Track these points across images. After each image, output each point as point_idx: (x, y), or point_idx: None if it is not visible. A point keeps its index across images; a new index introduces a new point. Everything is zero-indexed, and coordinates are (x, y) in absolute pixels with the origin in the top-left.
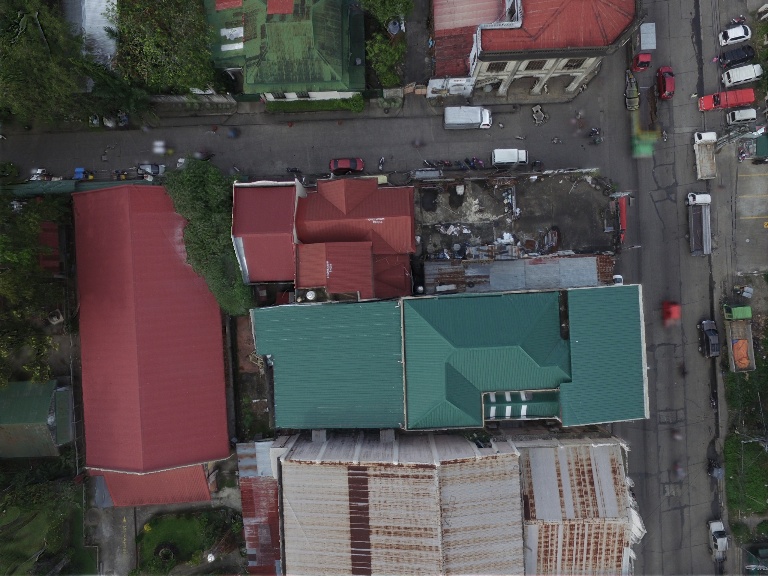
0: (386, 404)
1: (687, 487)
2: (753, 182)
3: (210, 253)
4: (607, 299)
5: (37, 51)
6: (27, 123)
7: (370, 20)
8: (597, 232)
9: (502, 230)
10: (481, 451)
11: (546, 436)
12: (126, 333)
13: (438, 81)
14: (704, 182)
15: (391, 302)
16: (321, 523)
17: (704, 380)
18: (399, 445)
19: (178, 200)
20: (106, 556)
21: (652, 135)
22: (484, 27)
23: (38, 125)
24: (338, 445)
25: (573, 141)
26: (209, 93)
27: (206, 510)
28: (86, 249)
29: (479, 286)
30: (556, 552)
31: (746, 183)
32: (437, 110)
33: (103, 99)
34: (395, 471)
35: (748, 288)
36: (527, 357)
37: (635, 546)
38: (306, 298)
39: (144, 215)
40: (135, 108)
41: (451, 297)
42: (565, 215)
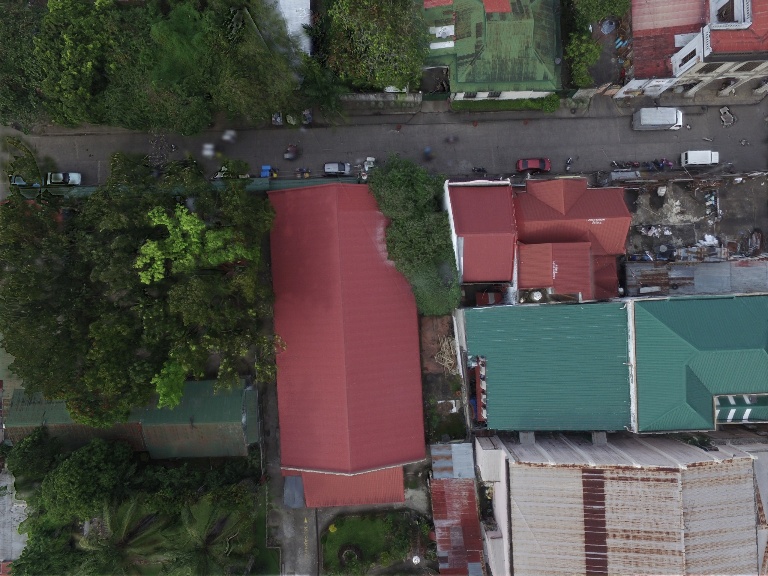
0: (609, 406)
1: None
2: None
3: (421, 253)
4: None
5: (259, 47)
6: None
7: (565, 20)
8: None
9: (703, 232)
10: None
11: (765, 440)
12: (331, 332)
13: (643, 82)
14: None
15: (616, 303)
16: (552, 526)
17: None
18: (617, 448)
19: (391, 199)
20: (287, 557)
21: None
22: (712, 28)
23: (221, 122)
24: (552, 447)
25: (761, 143)
26: (403, 92)
27: (390, 512)
28: (283, 247)
29: (683, 288)
30: None
31: None
32: (624, 111)
33: (309, 97)
34: (634, 474)
35: None
36: (767, 360)
37: None
38: (527, 299)
39: (350, 214)
40: (335, 106)
41: (683, 299)
42: (767, 217)
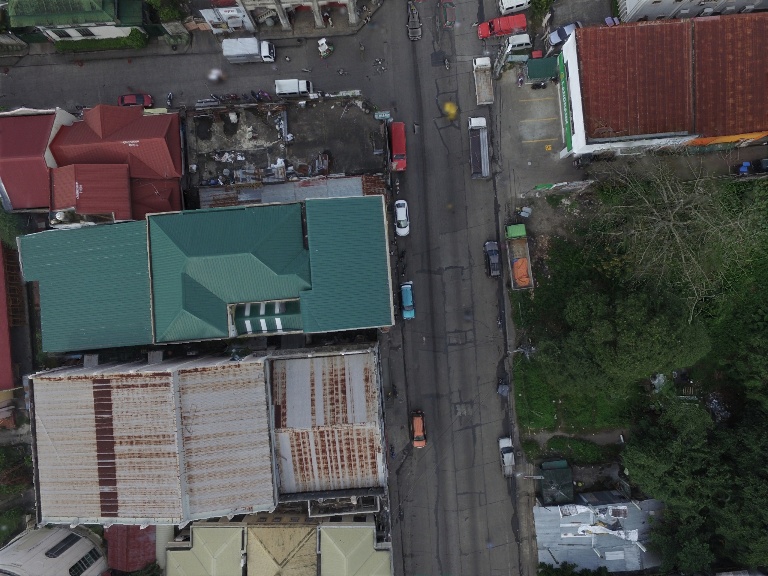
0: (141, 322)
1: (478, 406)
2: (534, 107)
3: None
4: (348, 209)
5: None
6: None
7: None
8: (369, 155)
9: (276, 156)
10: None
11: (306, 350)
12: None
13: (206, 11)
14: (487, 108)
15: (143, 221)
16: (70, 438)
17: (492, 301)
18: (161, 363)
19: None
20: None
21: (434, 64)
22: None
23: None
24: (104, 367)
25: (358, 72)
26: None
27: (4, 447)
28: None
29: None
30: (311, 460)
31: (527, 108)
32: None
33: None
34: (135, 381)
35: (526, 208)
36: (262, 265)
37: (429, 466)
38: None
39: None
40: None
41: (195, 212)
42: (337, 139)
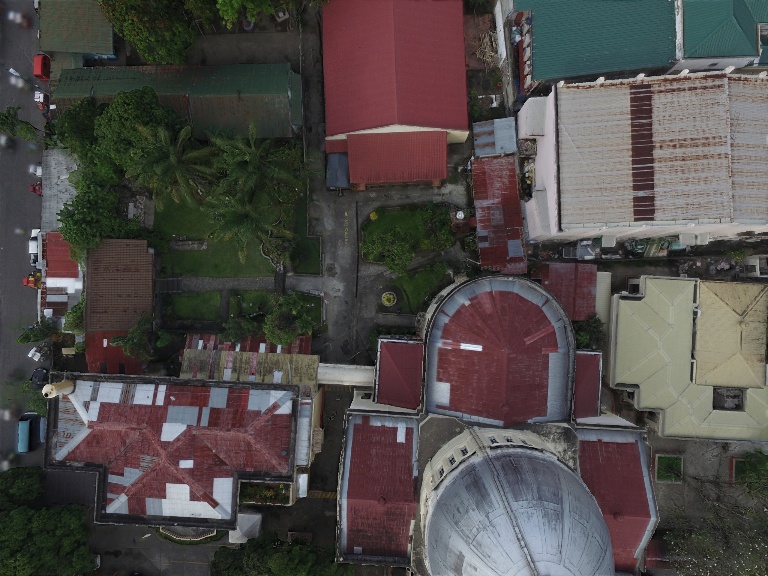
0: (655, 44)
1: None
2: None
3: None
4: None
5: None
6: None
7: None
8: None
9: None
10: None
11: None
12: None
13: None
14: None
15: None
16: (600, 144)
17: None
18: None
19: None
20: (327, 249)
21: None
22: None
23: None
24: None
25: None
26: None
27: None
28: None
29: None
30: None
31: None
32: None
33: None
34: (681, 85)
35: None
36: None
37: None
38: None
39: None
40: None
41: None
42: None
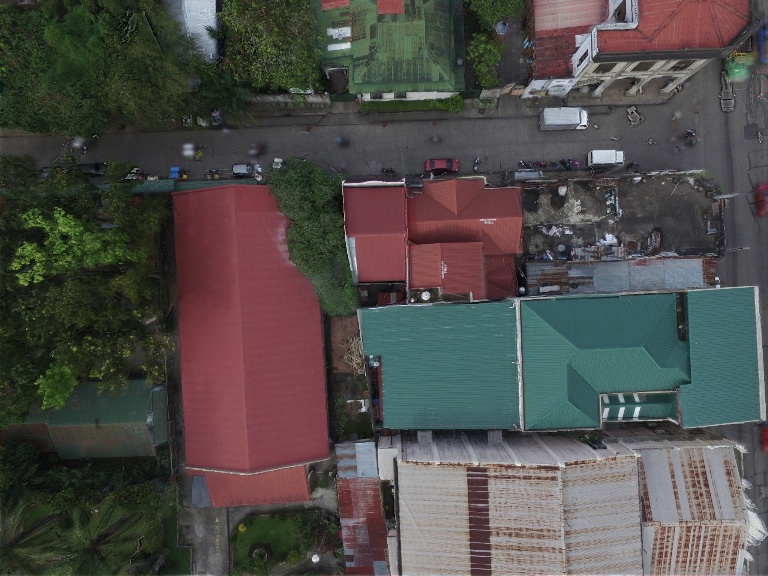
0: (499, 405)
1: None
2: None
3: (318, 253)
4: (725, 301)
5: (150, 50)
6: (123, 122)
7: (469, 20)
8: (699, 234)
9: (604, 231)
10: (599, 452)
11: (657, 438)
12: (231, 333)
13: (542, 82)
14: None
15: (505, 303)
16: (439, 524)
17: None
18: (510, 446)
19: (286, 200)
20: (199, 556)
21: (747, 137)
22: (600, 28)
23: (132, 124)
24: (447, 446)
25: (668, 142)
26: (308, 93)
27: (300, 511)
28: (187, 249)
29: (583, 287)
30: (671, 554)
31: None
32: (532, 111)
33: (208, 98)
34: (516, 472)
35: None
36: (649, 358)
37: None
38: (418, 299)
39: (249, 215)
40: (237, 107)
41: (569, 298)
42: (667, 216)
